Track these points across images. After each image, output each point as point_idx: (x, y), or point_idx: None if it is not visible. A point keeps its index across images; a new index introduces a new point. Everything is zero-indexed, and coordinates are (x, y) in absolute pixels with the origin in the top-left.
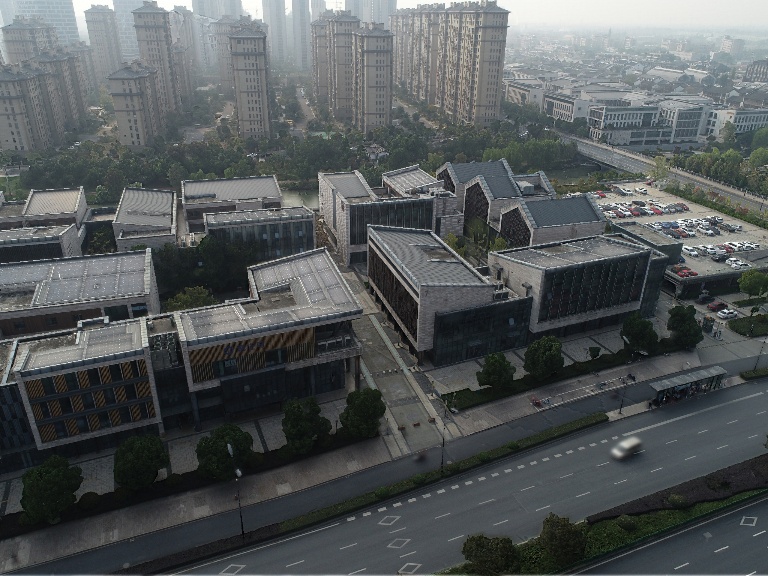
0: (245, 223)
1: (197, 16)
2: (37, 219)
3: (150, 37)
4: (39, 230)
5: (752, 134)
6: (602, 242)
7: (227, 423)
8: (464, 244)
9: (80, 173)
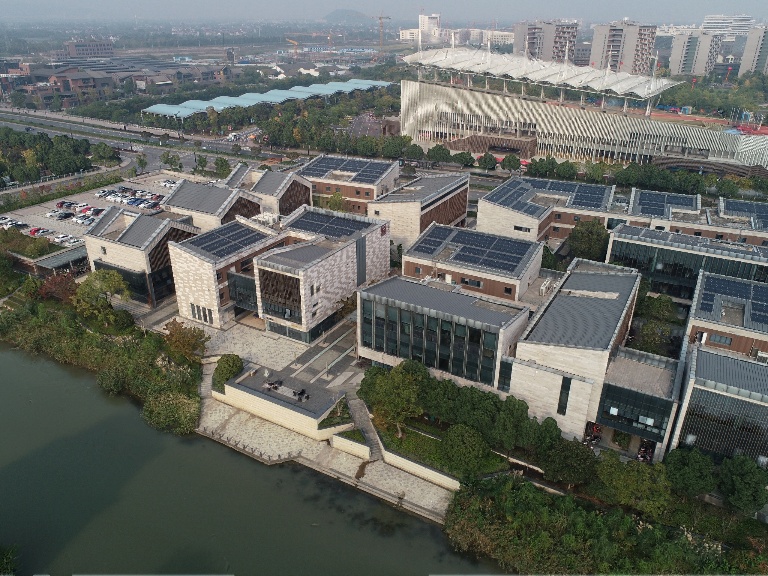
0: None
1: None
2: None
3: None
4: (742, 325)
5: None
6: (308, 170)
7: None
8: None
9: None
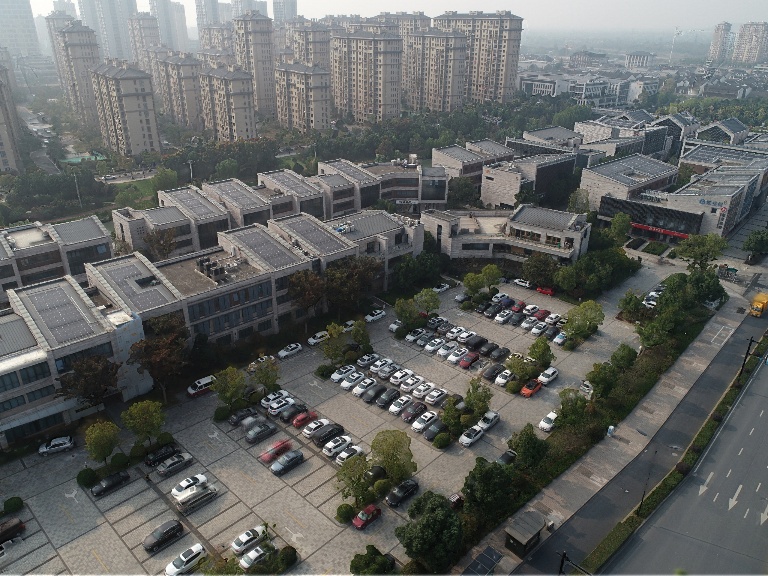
0: (626, 143)
1: (273, 22)
2: (500, 157)
3: (264, 41)
4: None
5: (656, 97)
6: None
7: (751, 215)
8: (675, 153)
9: (348, 147)
